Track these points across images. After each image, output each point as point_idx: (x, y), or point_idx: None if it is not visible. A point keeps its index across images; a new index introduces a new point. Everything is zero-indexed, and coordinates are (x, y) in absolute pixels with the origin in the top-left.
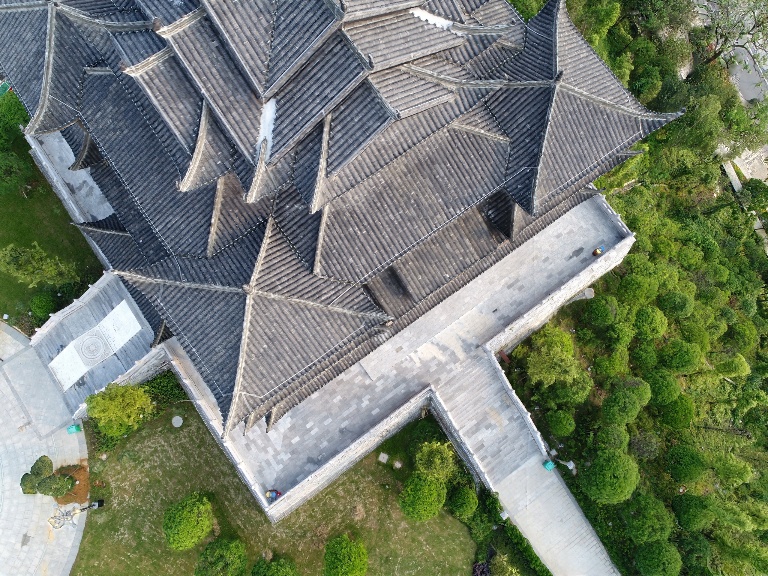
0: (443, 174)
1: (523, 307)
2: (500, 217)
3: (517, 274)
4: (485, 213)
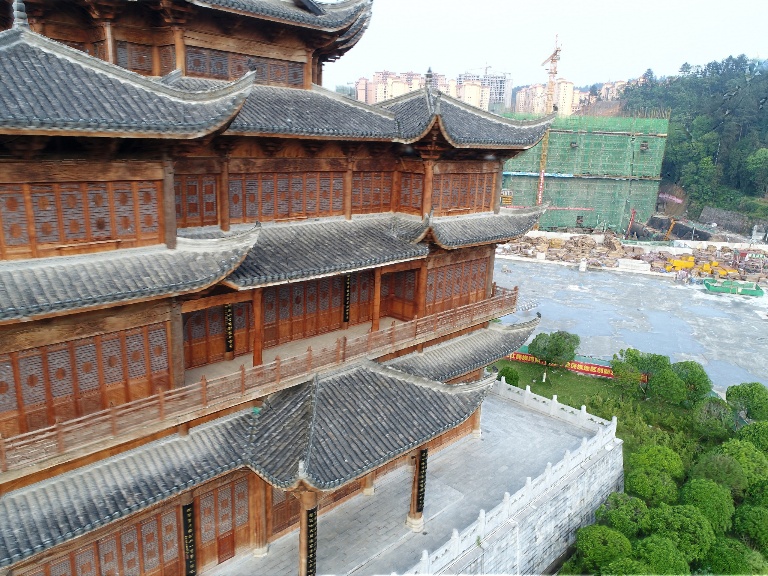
0: None
1: None
2: None
3: None
4: None
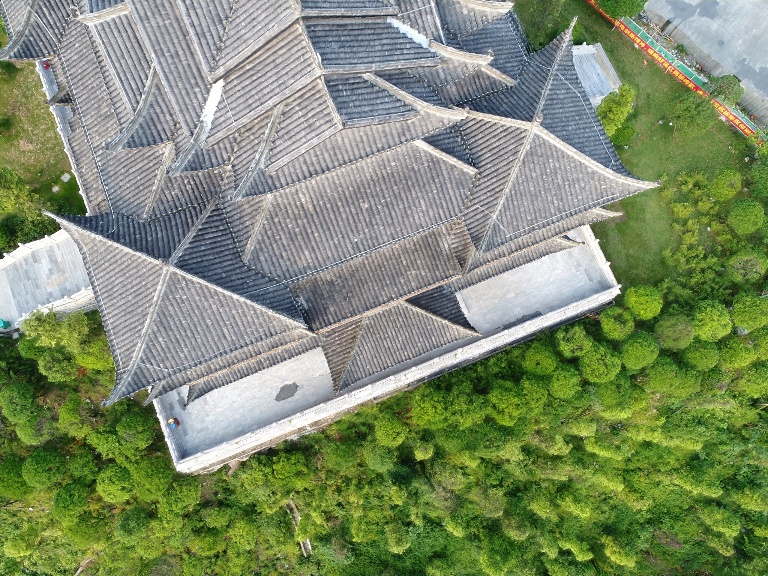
0: None
1: None
2: None
3: None
4: None
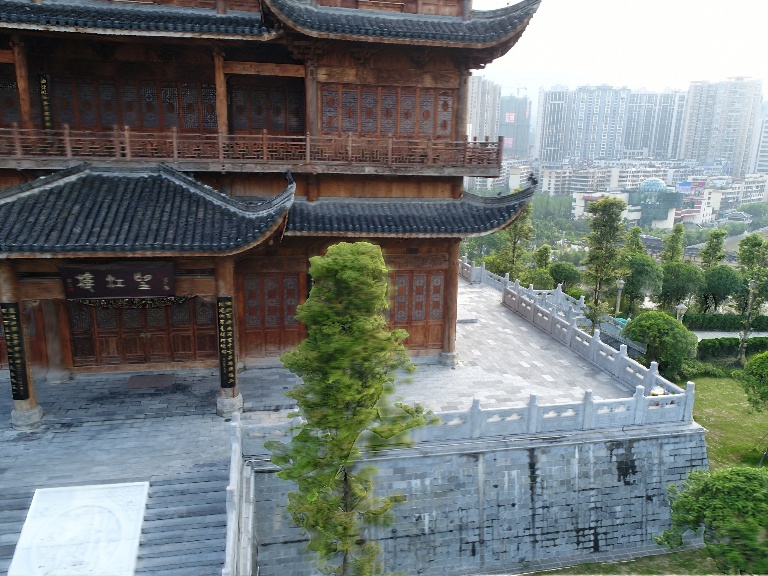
0: None
1: None
2: None
3: None
4: None
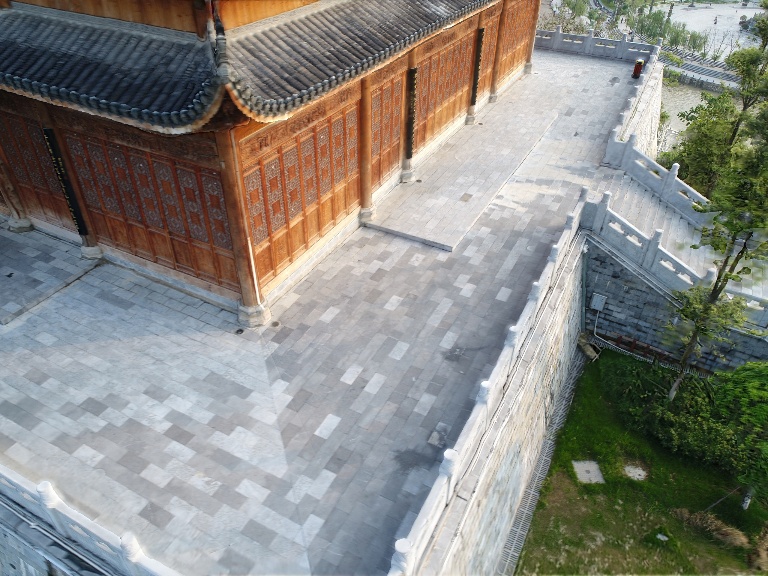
0: None
1: (610, 124)
2: None
3: (564, 105)
4: None
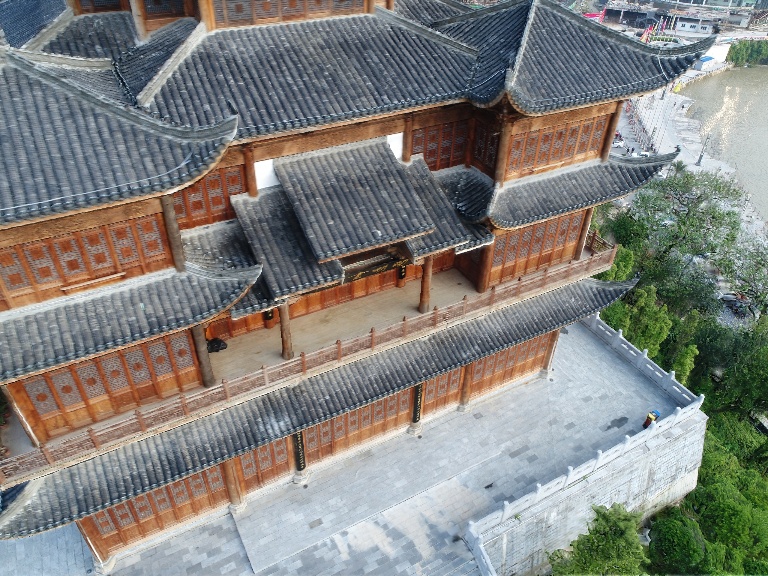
0: (378, 61)
1: None
2: (474, 208)
3: (525, 439)
4: (453, 207)
